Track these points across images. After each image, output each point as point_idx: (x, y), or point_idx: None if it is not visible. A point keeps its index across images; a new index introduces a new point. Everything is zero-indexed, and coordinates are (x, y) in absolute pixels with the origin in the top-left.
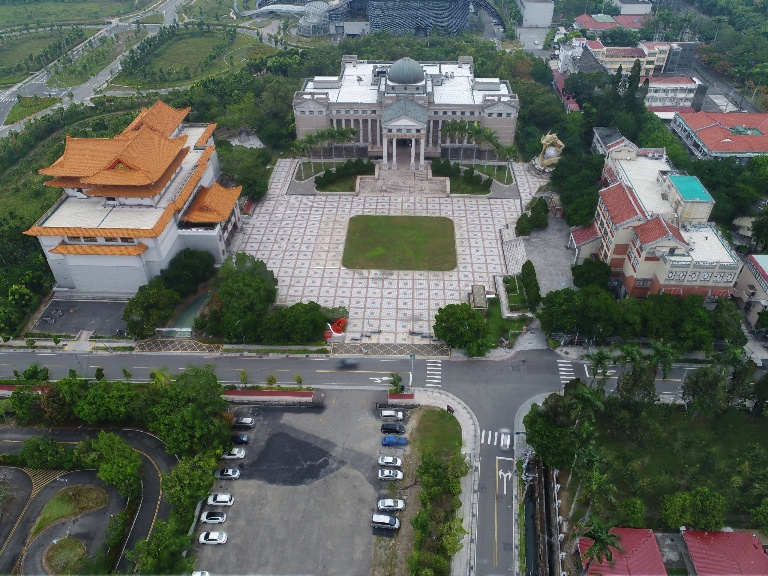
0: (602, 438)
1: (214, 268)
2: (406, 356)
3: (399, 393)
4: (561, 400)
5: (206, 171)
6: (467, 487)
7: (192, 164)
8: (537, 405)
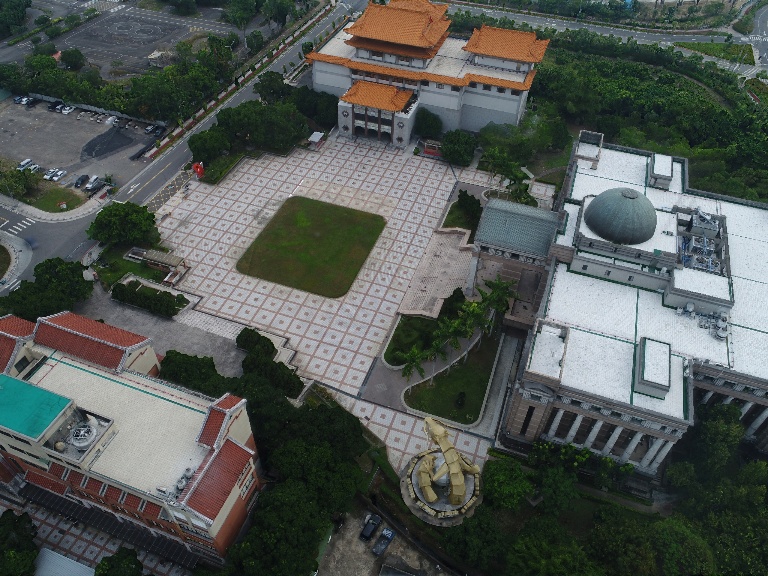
0: None
1: None
2: (144, 205)
3: None
4: None
5: (443, 94)
6: (6, 201)
7: None
8: None
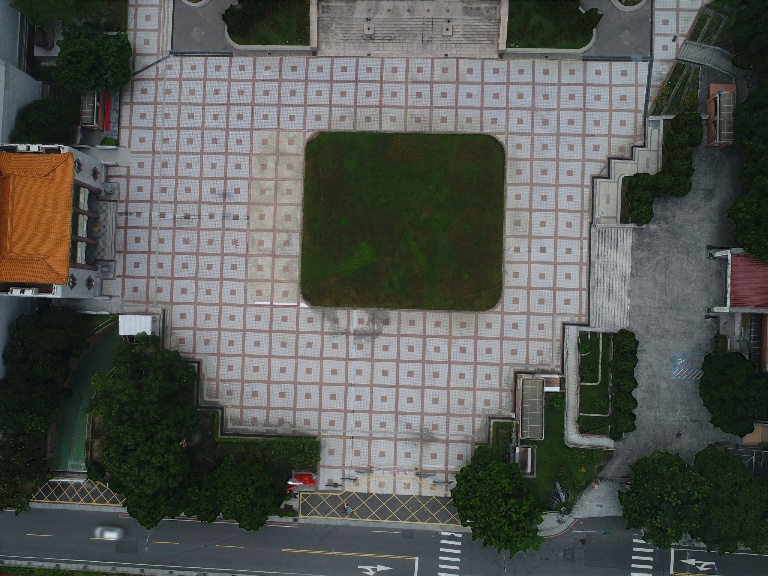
0: None
1: (84, 314)
2: (410, 524)
3: None
4: None
5: None
6: None
7: None
8: None
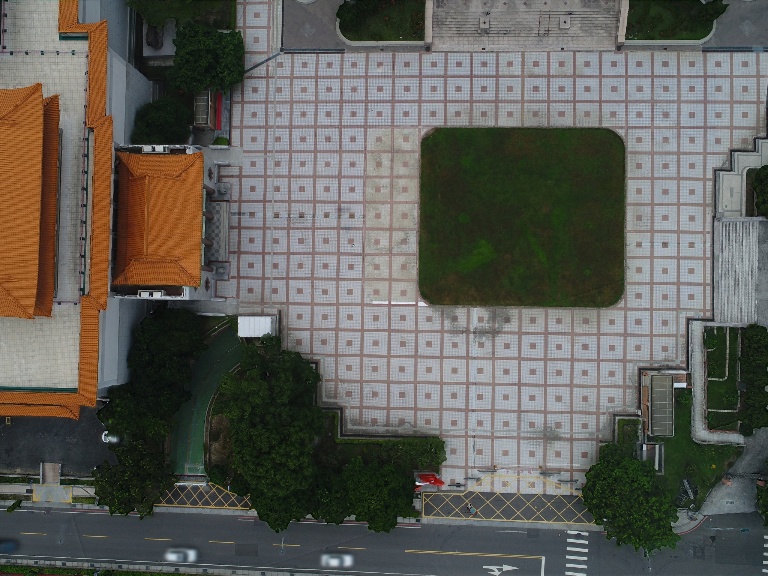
0: None
1: (200, 316)
2: (535, 523)
3: None
4: None
5: (110, 90)
6: None
7: (77, 112)
8: None
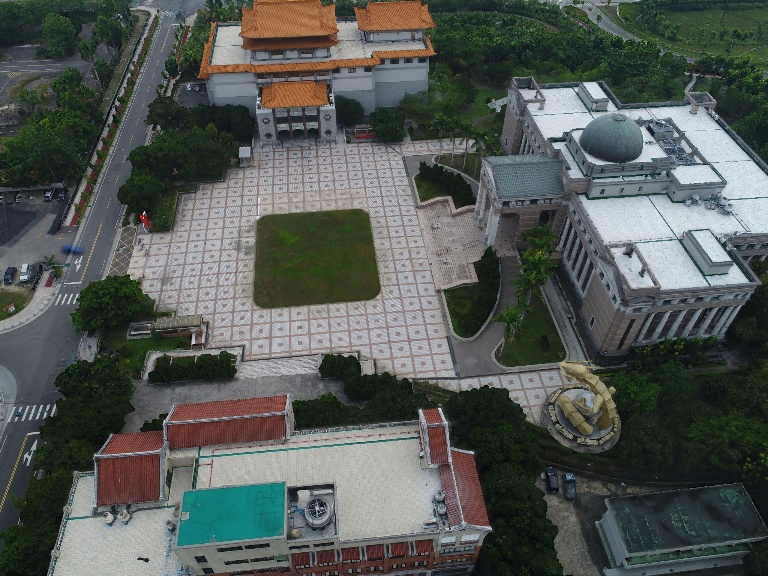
0: None
1: None
2: None
3: None
4: None
5: (356, 77)
6: None
7: None
8: None
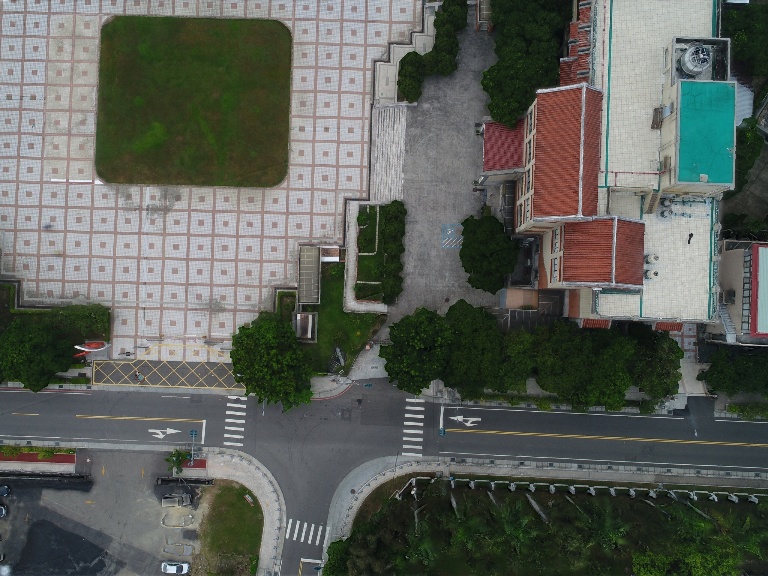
0: (432, 533)
1: None
2: (198, 389)
3: (187, 459)
4: (365, 572)
5: None
6: None
7: None
8: (342, 549)
